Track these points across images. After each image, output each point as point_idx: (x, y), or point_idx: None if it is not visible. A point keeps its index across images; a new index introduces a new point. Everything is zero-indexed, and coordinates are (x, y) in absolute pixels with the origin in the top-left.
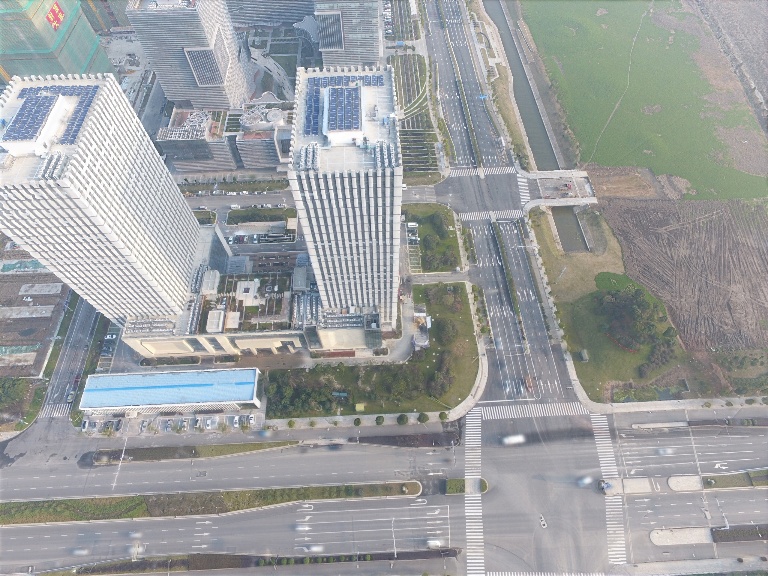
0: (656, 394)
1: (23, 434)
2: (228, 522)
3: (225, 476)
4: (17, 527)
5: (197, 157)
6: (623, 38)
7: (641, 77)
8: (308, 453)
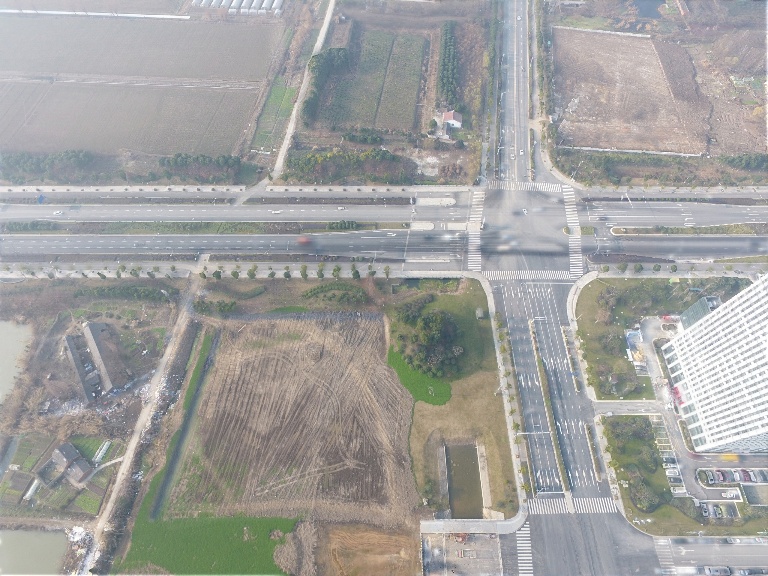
0: (420, 285)
1: None
2: (740, 220)
3: (758, 244)
4: None
5: None
6: None
7: None
8: (703, 255)
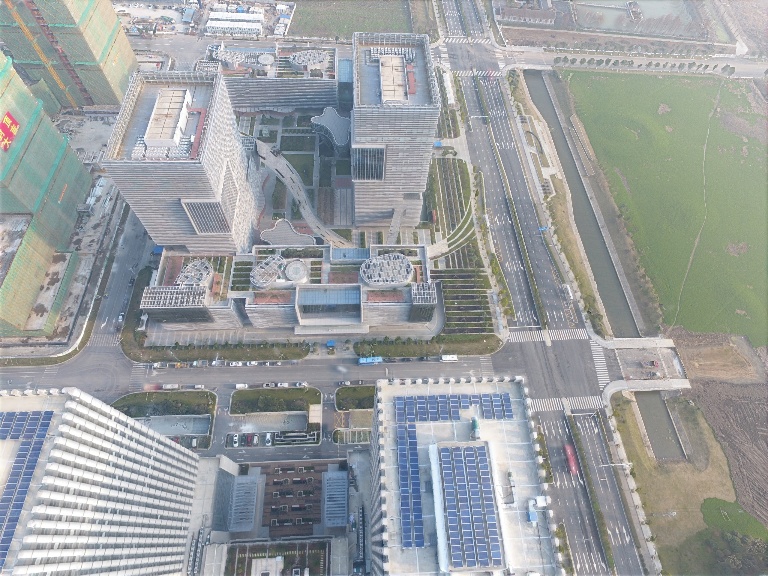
0: None
1: None
2: None
3: None
4: None
5: (193, 320)
6: (692, 146)
7: (719, 202)
8: None
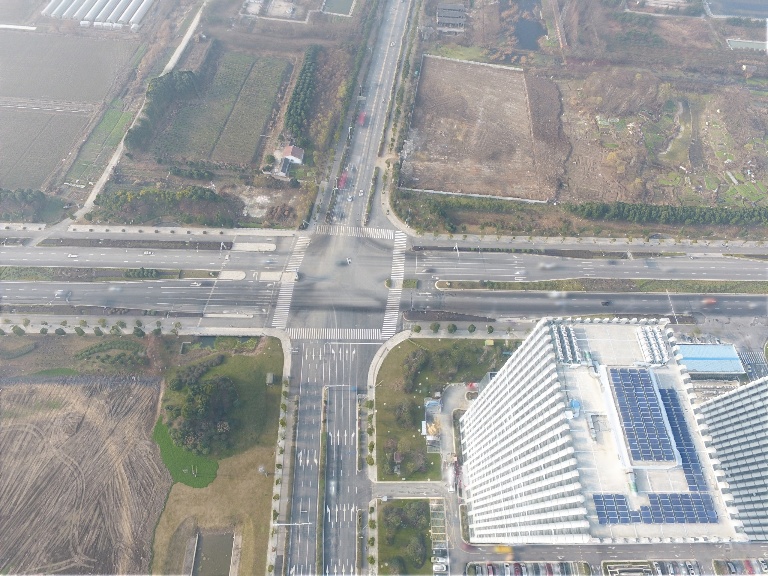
0: (215, 343)
1: (765, 340)
2: (573, 274)
3: (587, 301)
4: (718, 280)
5: None
6: None
7: None
8: (526, 313)
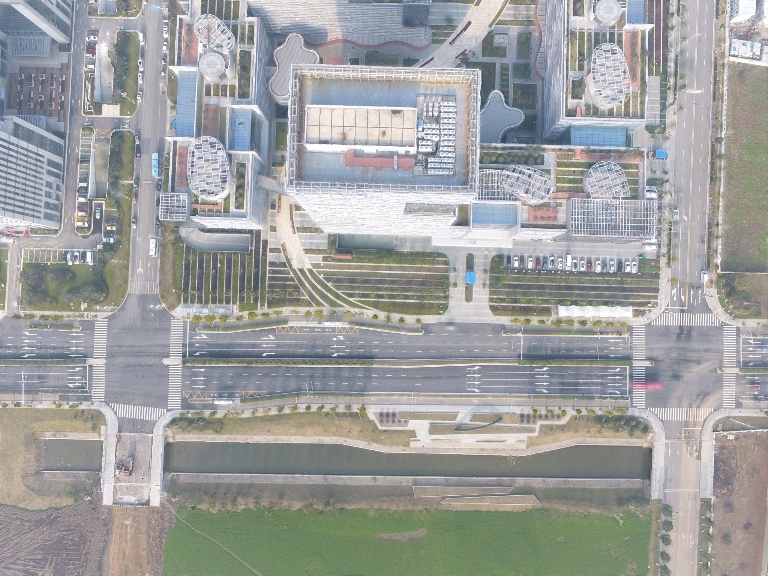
0: None
1: None
2: None
3: None
4: None
5: None
6: None
7: None
8: None
